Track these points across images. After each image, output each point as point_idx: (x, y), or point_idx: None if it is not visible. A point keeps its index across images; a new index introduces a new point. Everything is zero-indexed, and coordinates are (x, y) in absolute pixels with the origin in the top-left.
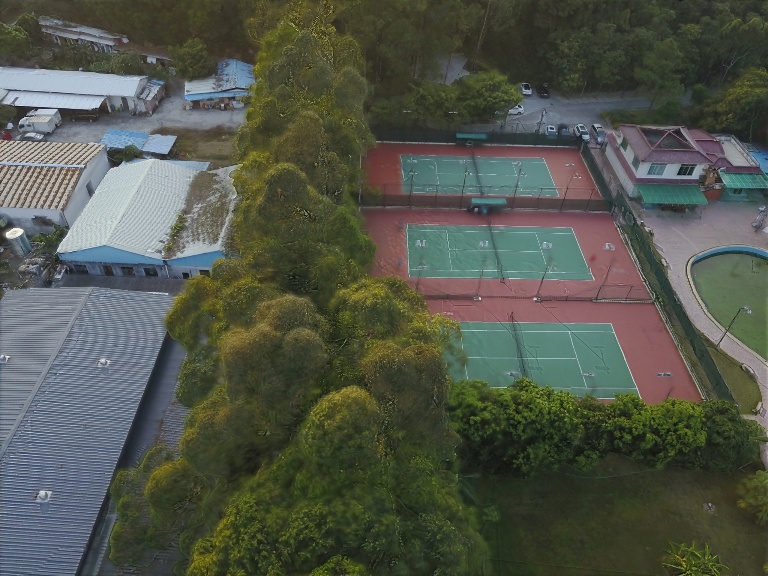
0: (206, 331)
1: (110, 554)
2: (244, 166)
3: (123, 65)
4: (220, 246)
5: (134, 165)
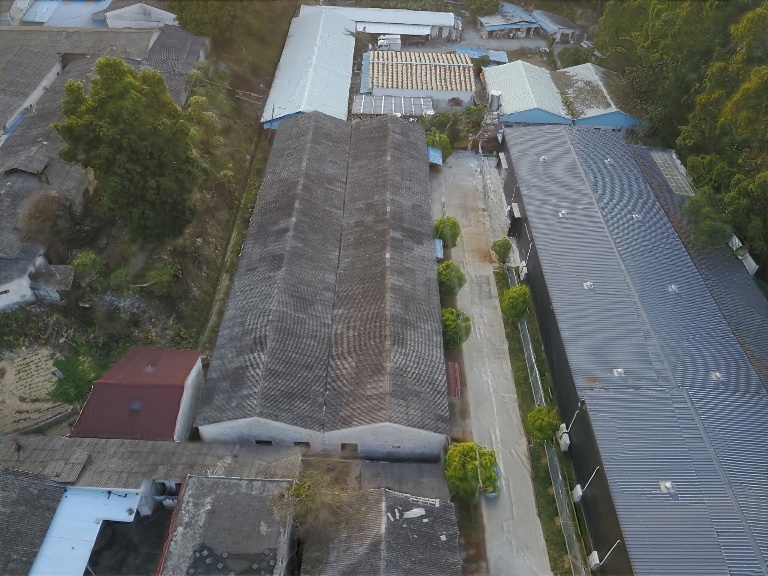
0: None
1: (704, 238)
2: (752, 17)
3: (435, 3)
4: (616, 108)
5: (505, 65)
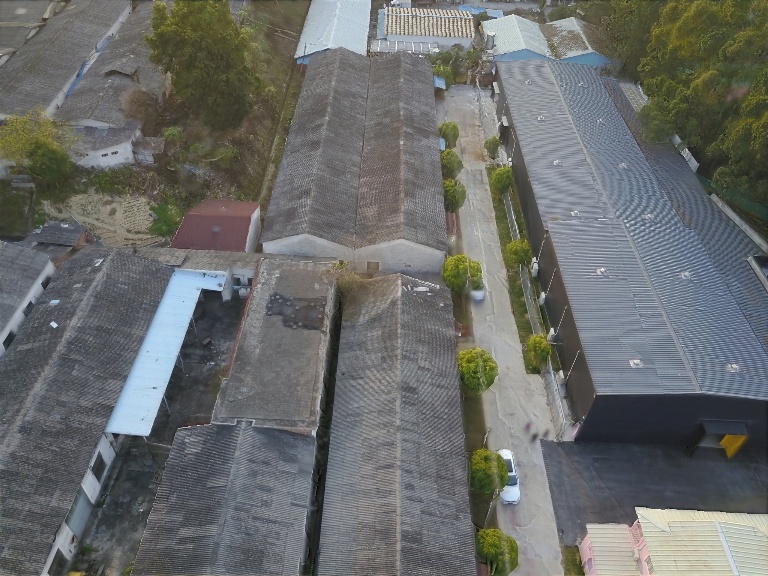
0: (712, 22)
1: (652, 135)
2: None
3: None
4: (592, 50)
5: (501, 18)
